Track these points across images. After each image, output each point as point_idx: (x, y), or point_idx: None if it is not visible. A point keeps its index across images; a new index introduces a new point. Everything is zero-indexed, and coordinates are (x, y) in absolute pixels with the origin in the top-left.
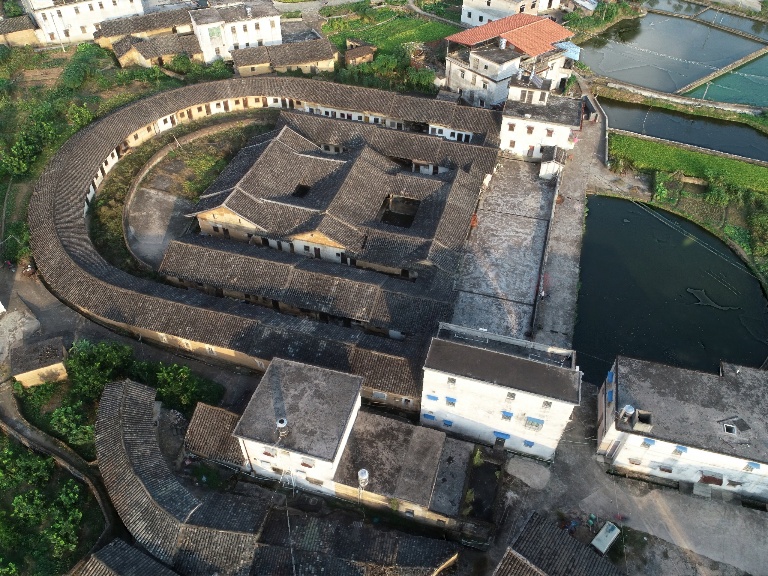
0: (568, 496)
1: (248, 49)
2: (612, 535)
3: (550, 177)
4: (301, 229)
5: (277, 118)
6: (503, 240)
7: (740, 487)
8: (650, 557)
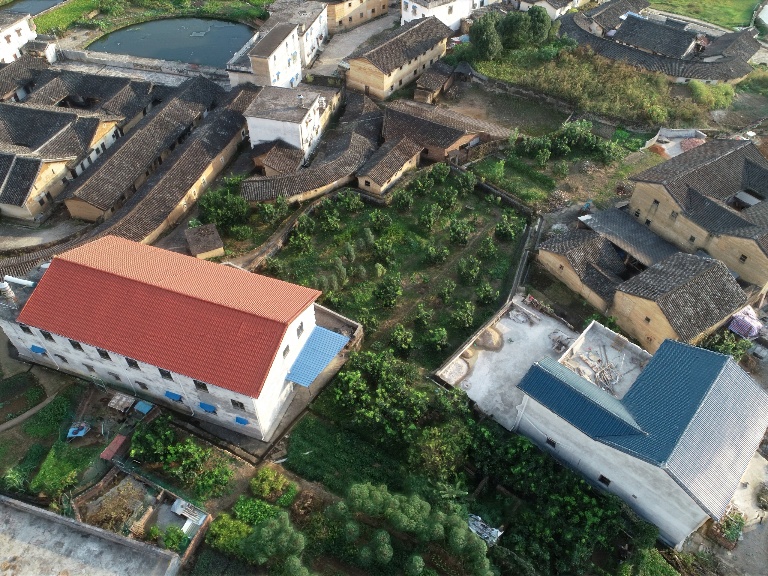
0: None
1: None
2: None
3: (55, 58)
4: (87, 135)
5: None
6: None
7: None
8: None
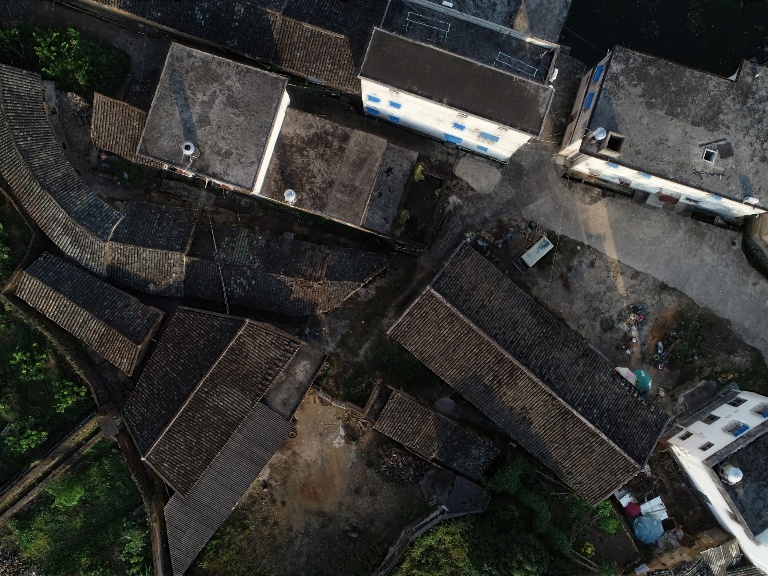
0: (513, 202)
1: None
2: (544, 251)
3: None
4: None
5: None
6: None
7: (696, 203)
8: (577, 266)
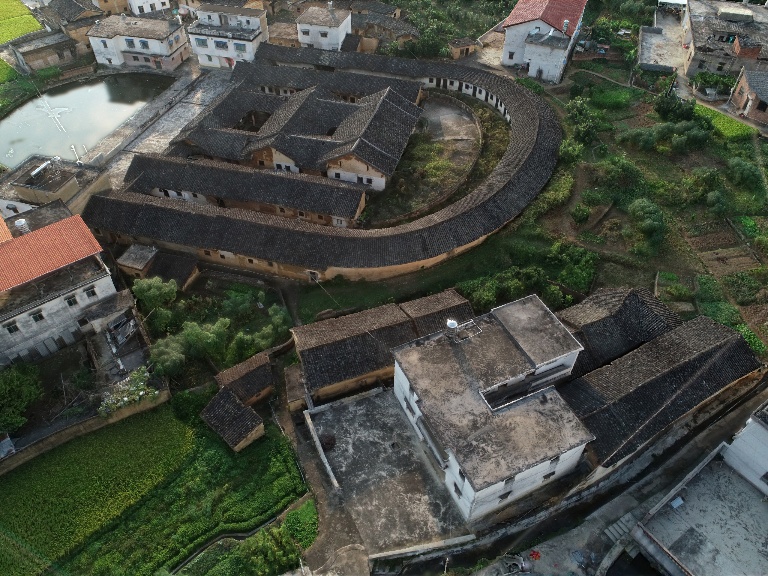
0: None
1: (441, 309)
2: None
3: None
4: (331, 95)
5: (373, 221)
6: (173, 135)
7: None
8: None
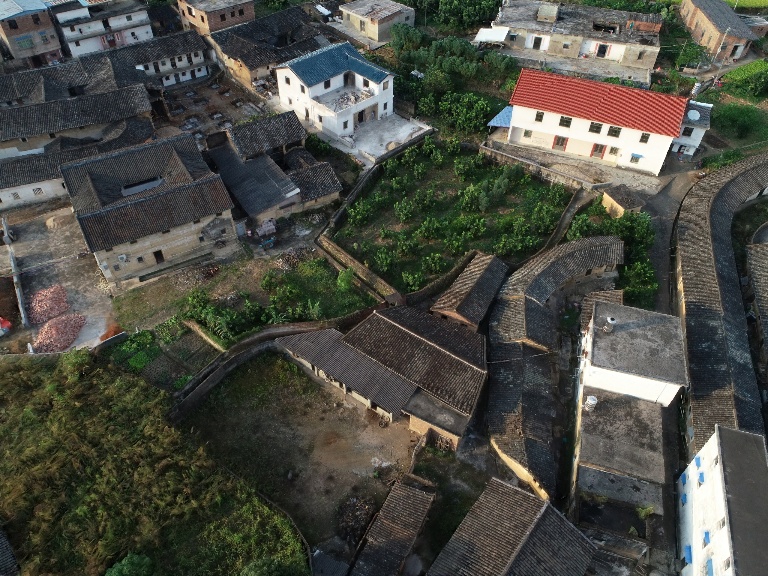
0: None
1: None
2: None
3: None
4: None
5: None
6: None
7: None
8: None
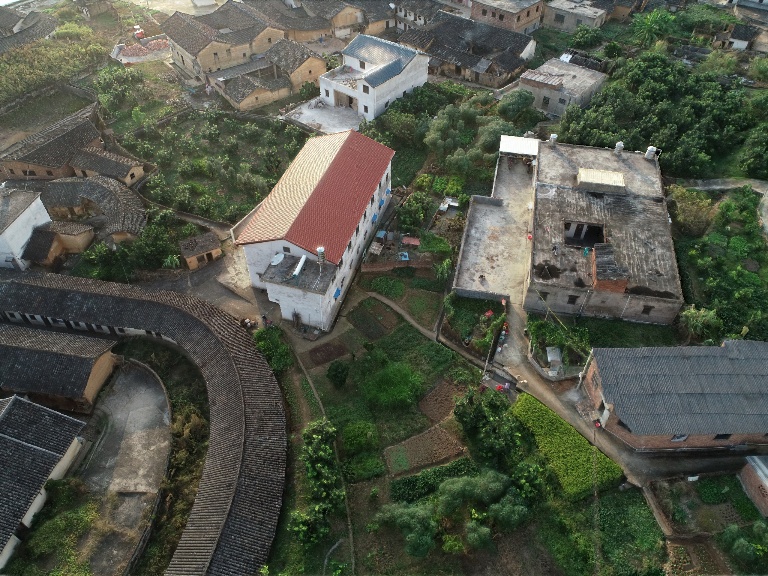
0: None
1: None
2: None
3: None
4: None
5: None
6: None
7: None
8: None
